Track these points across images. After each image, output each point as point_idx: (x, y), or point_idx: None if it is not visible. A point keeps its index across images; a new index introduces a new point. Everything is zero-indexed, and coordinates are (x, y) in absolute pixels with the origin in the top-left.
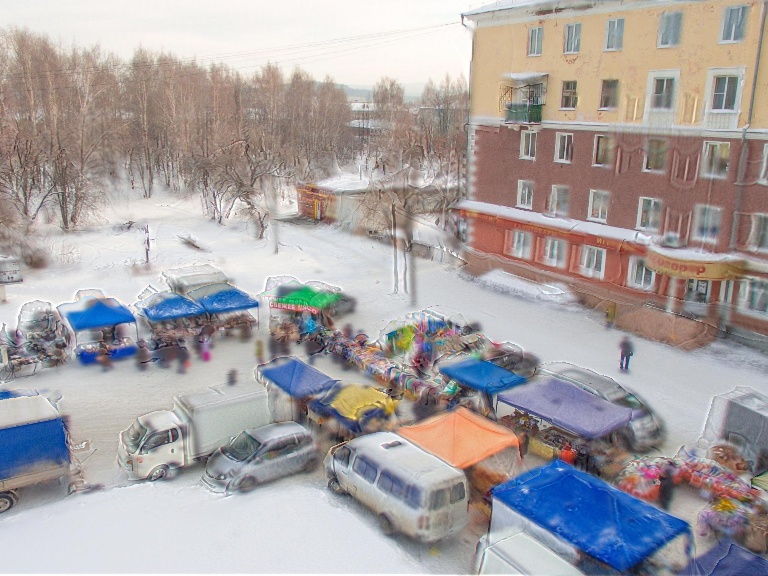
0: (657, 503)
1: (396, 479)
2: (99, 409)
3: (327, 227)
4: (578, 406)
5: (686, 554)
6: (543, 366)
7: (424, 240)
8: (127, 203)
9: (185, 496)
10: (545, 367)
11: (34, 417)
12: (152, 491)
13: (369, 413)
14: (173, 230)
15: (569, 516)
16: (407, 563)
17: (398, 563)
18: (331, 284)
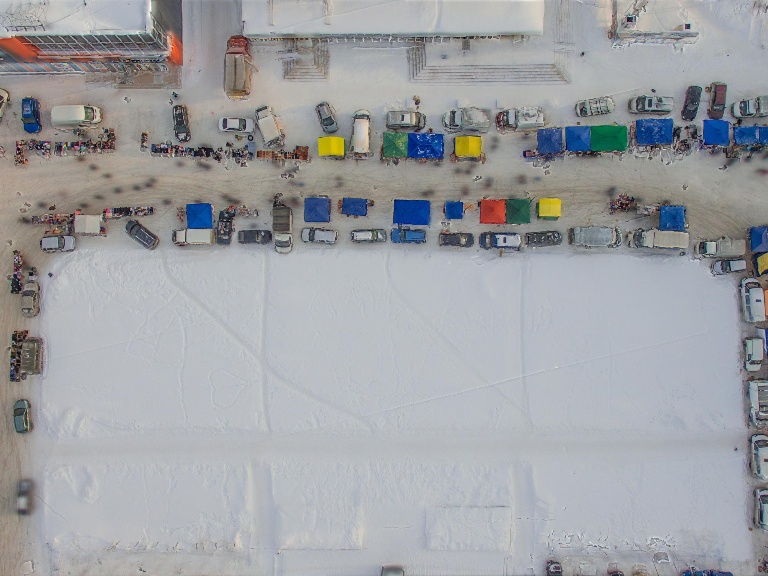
0: None
1: None
2: (697, 203)
3: None
4: None
5: None
6: None
7: None
8: None
9: (705, 272)
10: None
11: (685, 247)
12: (699, 266)
13: None
14: None
15: None
16: (738, 323)
17: (736, 323)
18: None
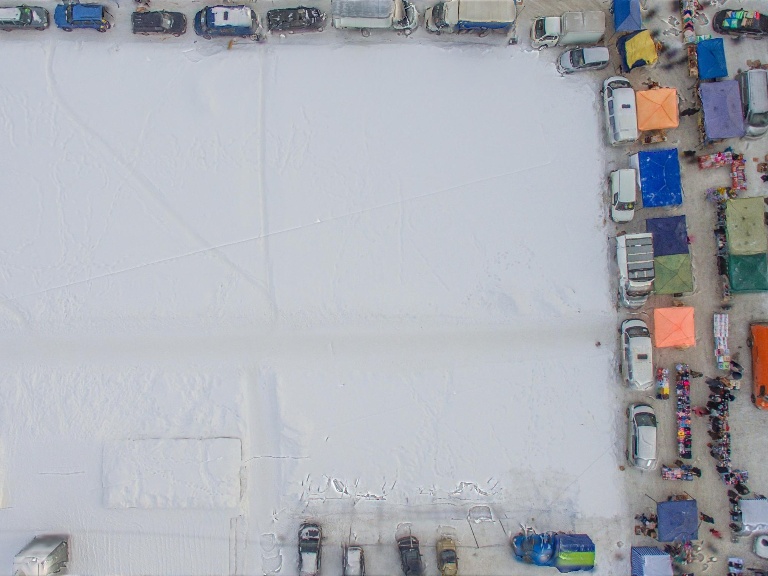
0: (708, 172)
1: (615, 125)
2: None
3: None
4: (720, 124)
5: None
6: (752, 73)
7: None
8: None
9: (548, 69)
10: (751, 75)
11: (507, 20)
12: (537, 60)
13: (640, 66)
14: None
15: (650, 178)
16: (600, 149)
17: (597, 148)
18: None
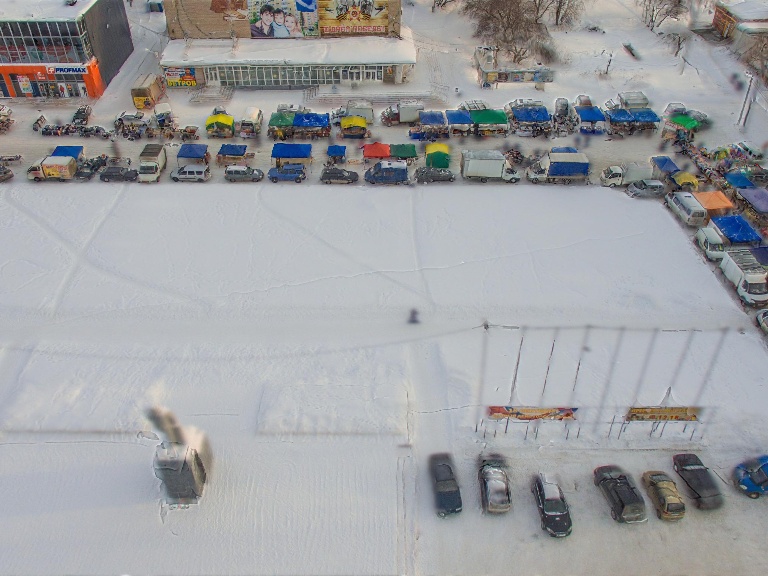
0: None
1: (684, 206)
2: (591, 157)
3: (725, 51)
4: (764, 203)
5: (755, 244)
6: None
7: (760, 103)
8: (593, 4)
9: (620, 194)
10: None
11: (585, 161)
12: (611, 190)
13: (687, 185)
14: (621, 38)
15: (728, 227)
16: (679, 227)
17: (676, 226)
18: (704, 109)
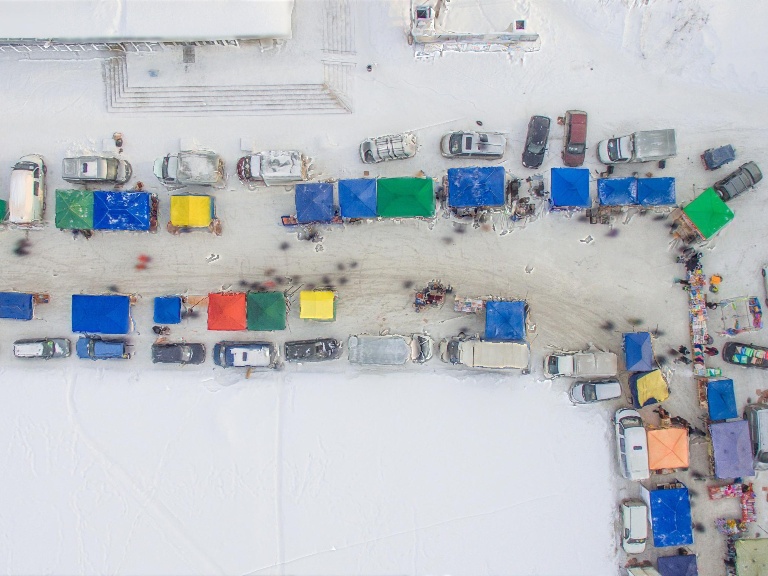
0: (718, 501)
1: None
2: (547, 292)
3: None
4: (730, 467)
5: None
6: (762, 413)
7: None
8: None
9: (560, 399)
10: (761, 416)
11: (521, 367)
12: (550, 390)
13: None
14: None
15: (662, 519)
16: (611, 478)
17: (608, 478)
18: None
